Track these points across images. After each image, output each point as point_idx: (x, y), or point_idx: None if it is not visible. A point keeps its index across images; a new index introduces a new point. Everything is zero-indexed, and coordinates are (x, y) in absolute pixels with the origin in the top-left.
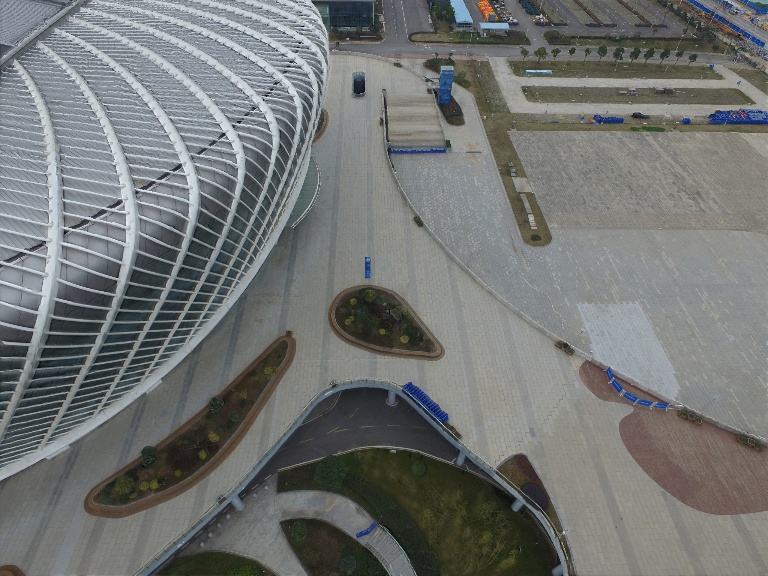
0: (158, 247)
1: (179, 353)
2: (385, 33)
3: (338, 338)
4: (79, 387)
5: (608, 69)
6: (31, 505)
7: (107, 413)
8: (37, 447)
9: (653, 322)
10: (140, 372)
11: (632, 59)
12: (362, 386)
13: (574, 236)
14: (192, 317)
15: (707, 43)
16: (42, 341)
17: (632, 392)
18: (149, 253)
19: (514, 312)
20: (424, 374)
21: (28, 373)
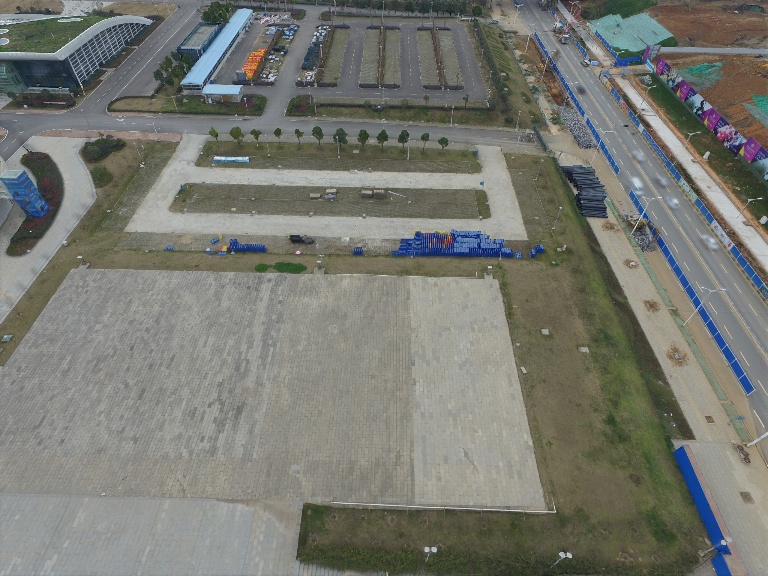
0: None
1: None
2: (87, 97)
3: None
4: None
5: (330, 155)
6: None
7: None
8: None
9: None
10: None
11: (361, 143)
12: None
13: None
14: None
15: (499, 114)
16: None
17: None
18: None
19: None
20: None
21: None
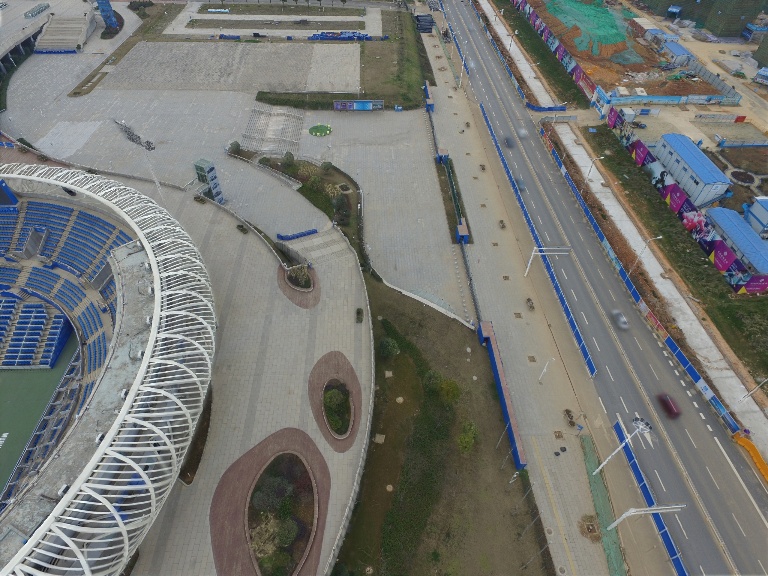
0: None
1: None
2: None
3: None
4: None
5: (277, 9)
6: None
7: None
8: None
9: (99, 129)
10: None
11: (295, 1)
12: None
13: (105, 93)
14: None
15: None
16: None
17: None
18: None
19: None
20: None
21: None
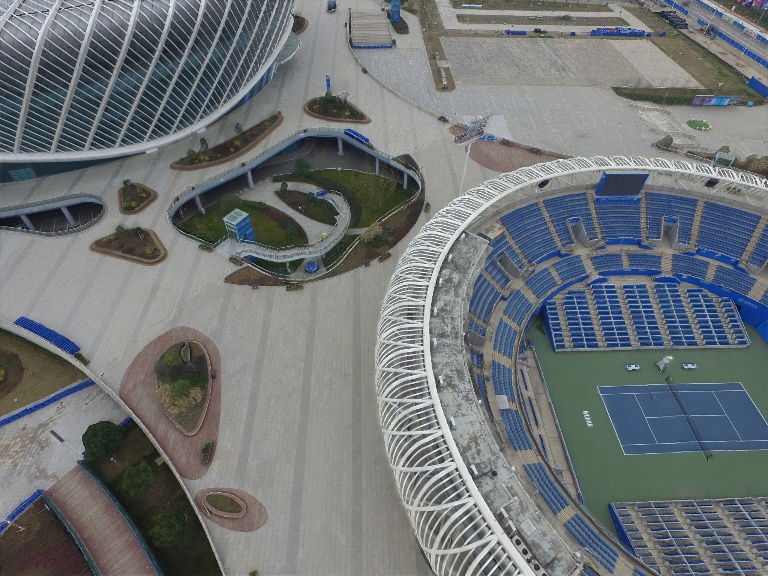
0: (215, 5)
1: (216, 113)
2: None
3: (309, 116)
4: (172, 90)
5: (526, 5)
6: (142, 167)
7: (177, 135)
8: (143, 140)
9: (509, 123)
10: (196, 110)
11: None
12: (322, 134)
13: (471, 87)
14: (225, 81)
15: None
16: (167, 32)
17: None
18: (211, 5)
19: (417, 107)
20: (358, 129)
21: (159, 51)
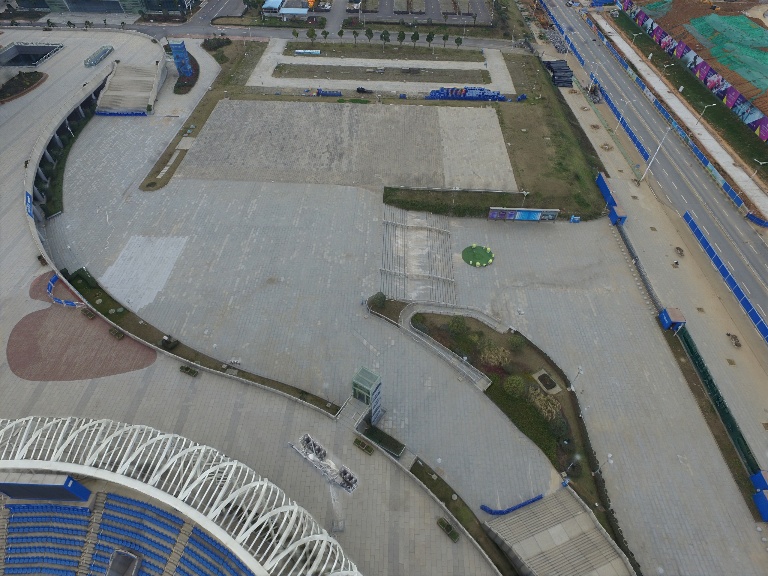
0: None
1: None
2: (193, 17)
3: None
4: None
5: (377, 51)
6: None
7: None
8: None
9: (184, 252)
10: None
11: (400, 42)
12: None
13: (187, 184)
14: None
15: (499, 30)
16: None
17: (63, 294)
18: None
19: None
20: None
21: None
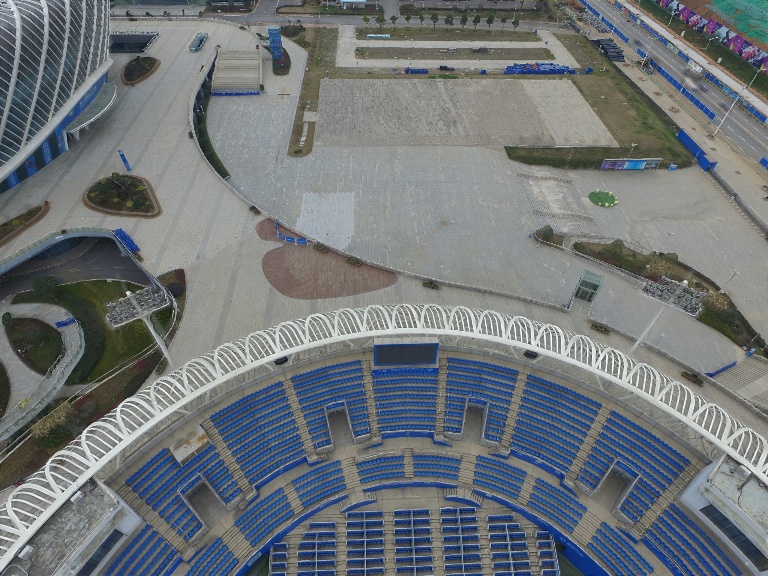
0: None
1: None
2: (257, 7)
3: (84, 206)
4: None
5: (442, 34)
6: None
7: None
8: None
9: (357, 204)
10: None
11: (462, 25)
12: (89, 235)
13: (330, 150)
14: None
15: (544, 13)
16: None
17: (289, 235)
18: None
19: (231, 190)
20: (138, 226)
21: None
